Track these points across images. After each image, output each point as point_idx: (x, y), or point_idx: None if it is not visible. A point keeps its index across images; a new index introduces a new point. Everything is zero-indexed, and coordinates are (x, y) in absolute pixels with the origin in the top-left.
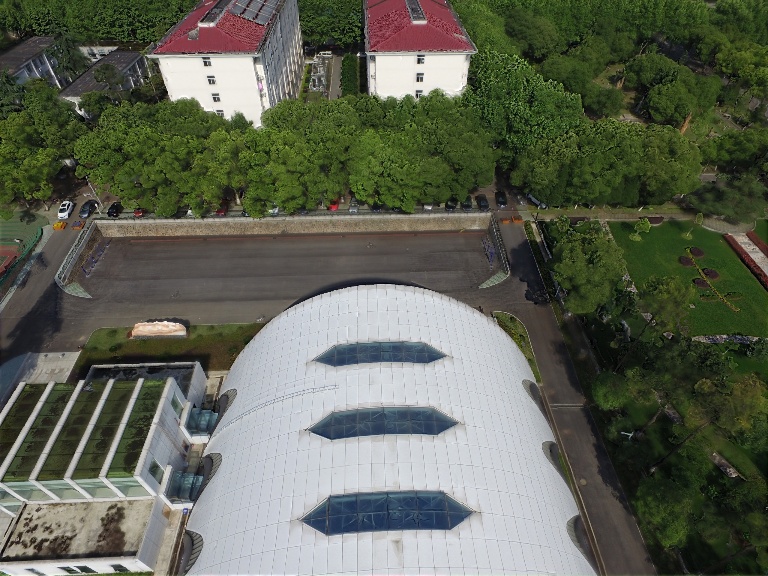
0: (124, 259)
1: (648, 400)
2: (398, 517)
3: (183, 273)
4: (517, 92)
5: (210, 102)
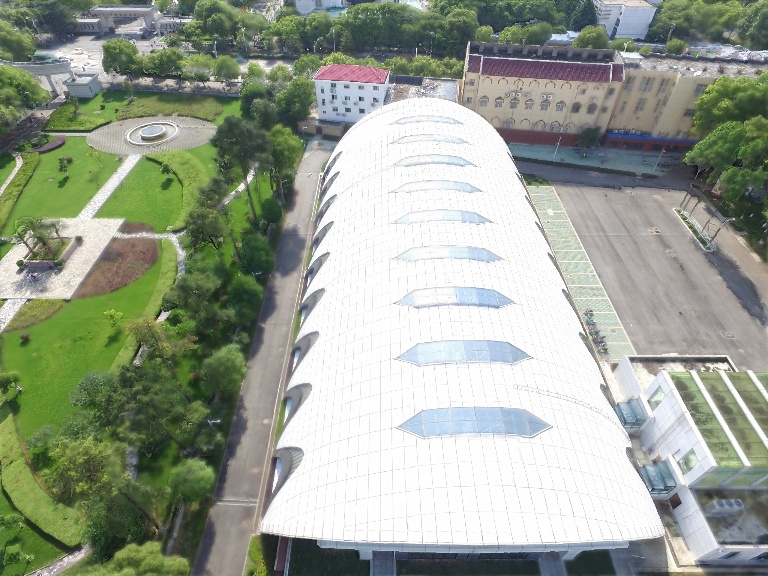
0: None
1: None
2: (448, 299)
3: None
4: None
5: None
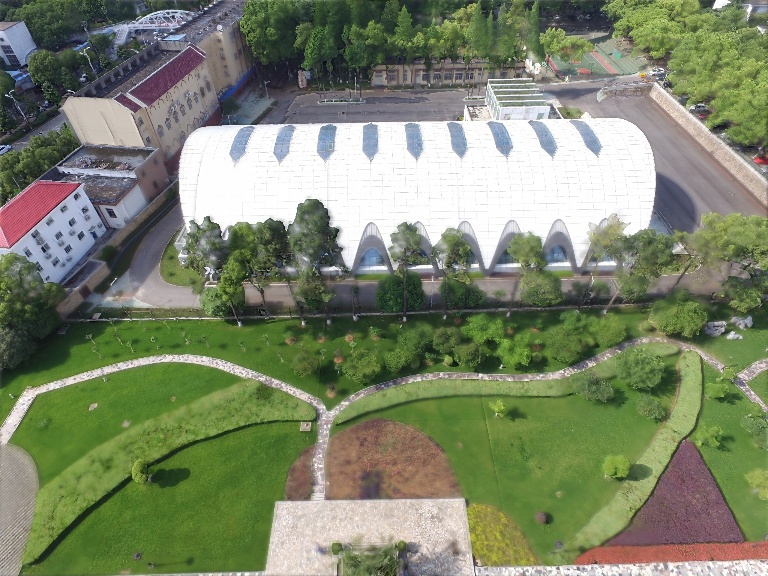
0: (635, 104)
1: None
2: None
3: (638, 123)
4: None
5: None
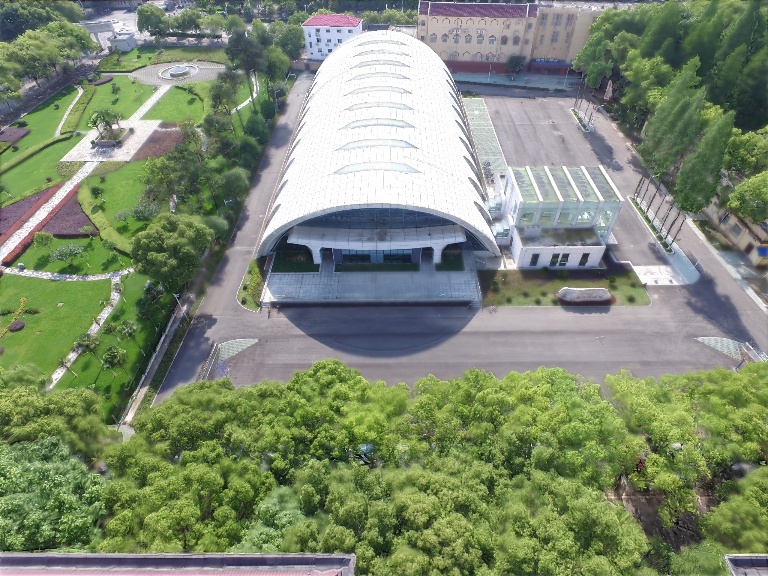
0: None
1: None
2: None
3: (616, 369)
4: None
5: None
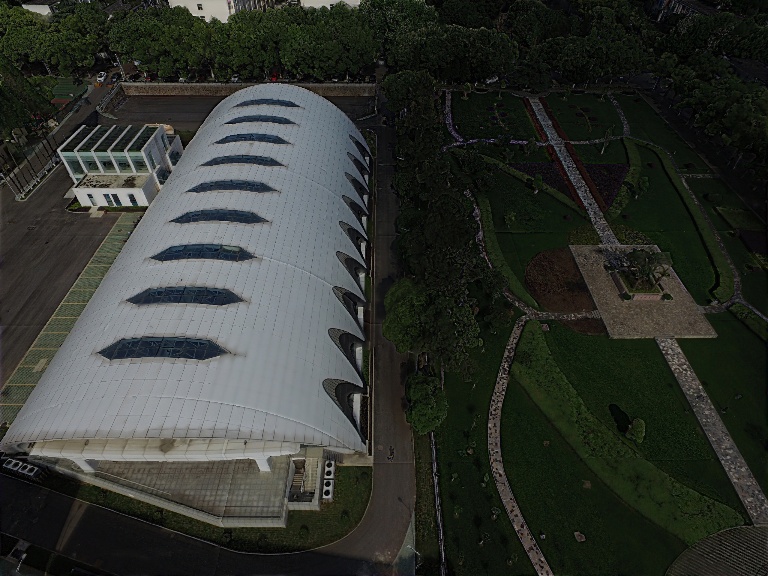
0: (138, 104)
1: None
2: None
3: (174, 111)
4: (393, 4)
5: (196, 10)
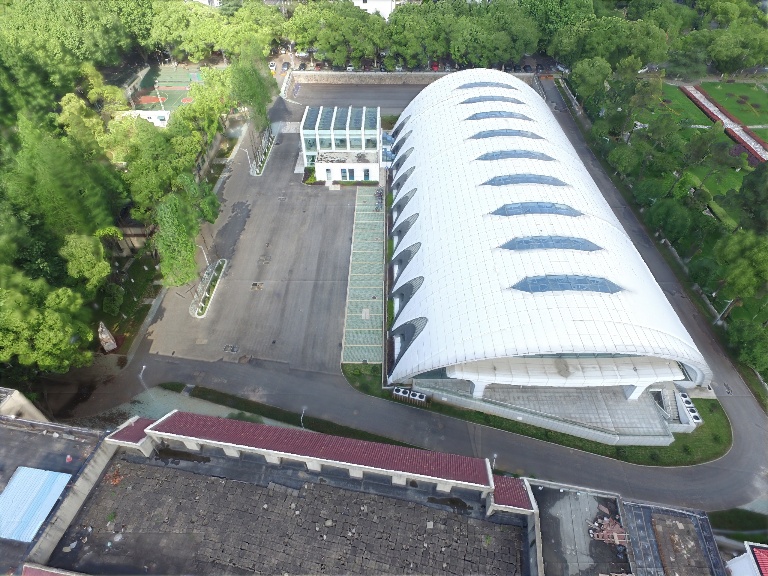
0: (312, 92)
1: (620, 138)
2: None
3: (350, 97)
4: None
5: (361, 3)
